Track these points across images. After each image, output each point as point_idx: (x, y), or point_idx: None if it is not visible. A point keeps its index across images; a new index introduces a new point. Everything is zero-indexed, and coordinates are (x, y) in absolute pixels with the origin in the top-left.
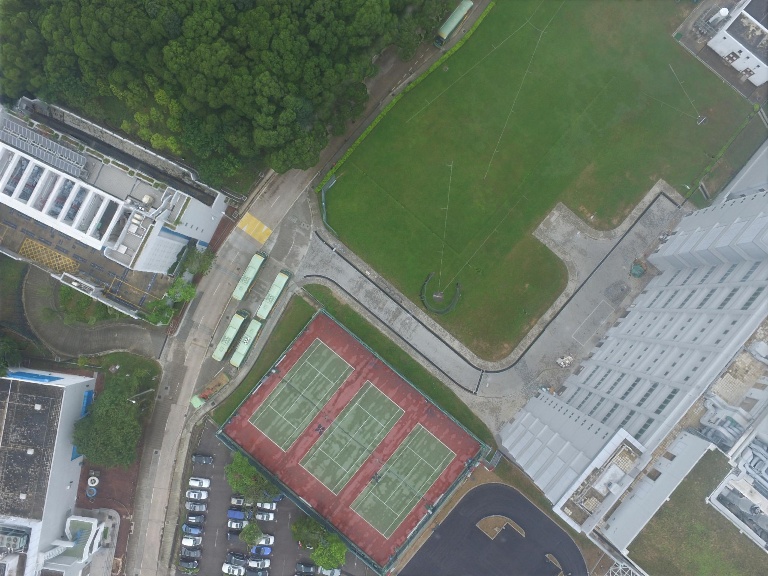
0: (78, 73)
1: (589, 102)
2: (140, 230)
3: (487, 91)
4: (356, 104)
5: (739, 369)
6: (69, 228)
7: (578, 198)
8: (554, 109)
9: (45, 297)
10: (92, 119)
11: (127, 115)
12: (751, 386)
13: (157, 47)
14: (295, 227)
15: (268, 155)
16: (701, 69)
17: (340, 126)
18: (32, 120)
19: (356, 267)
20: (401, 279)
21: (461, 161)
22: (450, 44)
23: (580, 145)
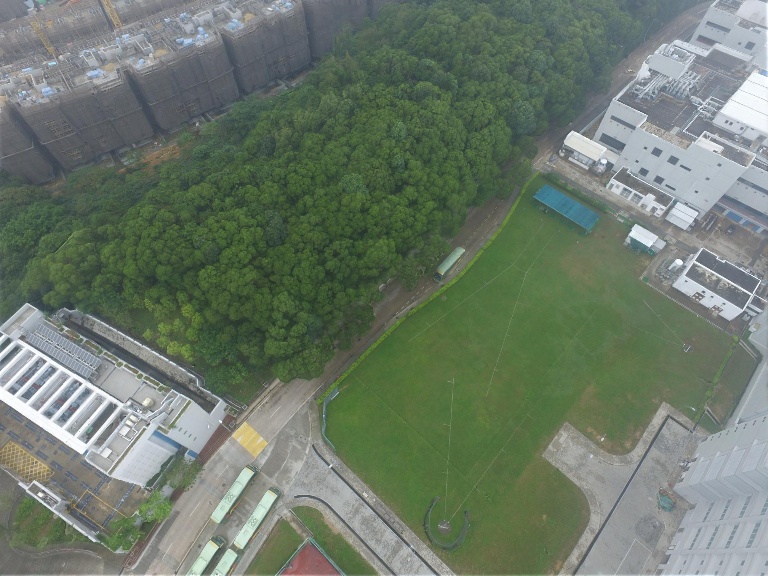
0: (120, 289)
1: (578, 329)
2: (131, 433)
3: (482, 317)
4: (363, 323)
5: None
6: (59, 429)
7: (584, 419)
8: (546, 334)
9: (1, 511)
10: (119, 327)
11: (152, 325)
12: None
13: (195, 270)
14: (292, 439)
15: (275, 364)
16: (673, 305)
17: (347, 341)
18: (64, 326)
19: (353, 487)
20: (402, 504)
21: (462, 378)
22: (447, 279)
23: (576, 367)
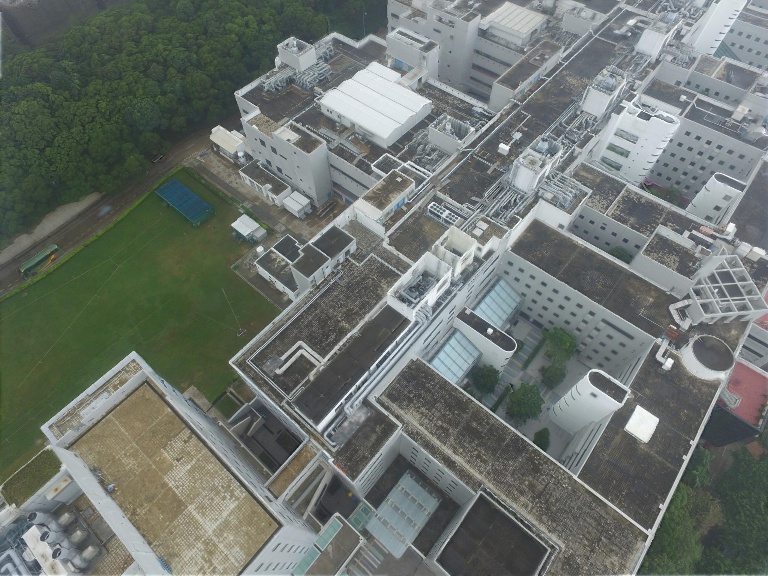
0: None
1: (142, 319)
2: None
3: (53, 311)
4: None
5: None
6: None
7: None
8: (108, 325)
9: None
10: None
11: None
12: None
13: None
14: None
15: None
16: (250, 291)
17: None
18: None
19: None
20: None
21: (3, 372)
22: None
23: (122, 356)
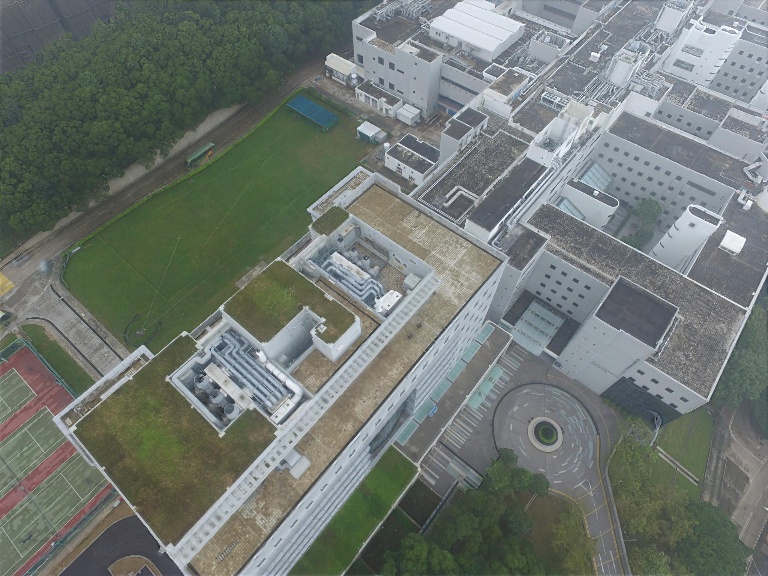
0: None
1: (294, 198)
2: None
3: (219, 193)
4: (97, 190)
5: None
6: None
7: None
8: (267, 203)
9: None
10: None
11: None
12: None
13: None
14: (35, 282)
15: None
16: None
17: (81, 204)
18: None
19: (75, 311)
20: (111, 319)
21: (187, 235)
22: None
23: (284, 224)
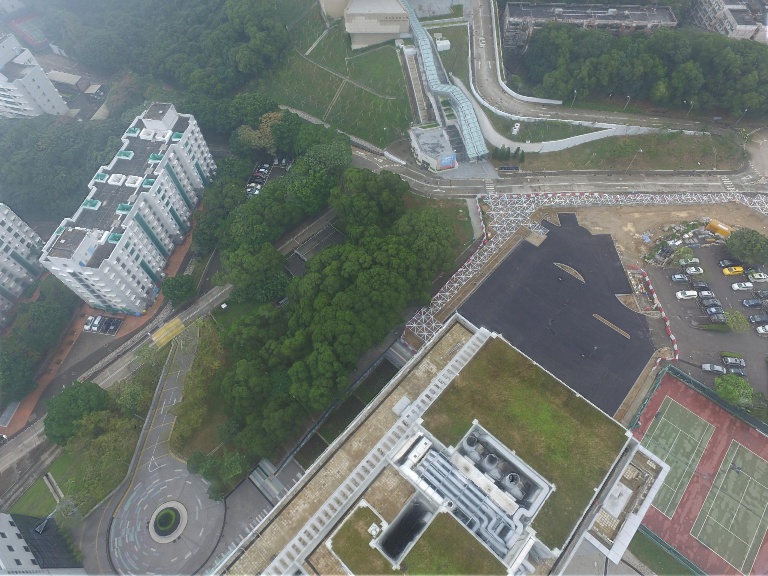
0: None
1: None
2: None
3: None
4: None
5: None
6: None
7: None
8: None
9: None
10: None
11: None
12: None
13: None
14: None
15: None
16: None
17: None
18: None
19: None
20: None
21: None
22: None
23: None
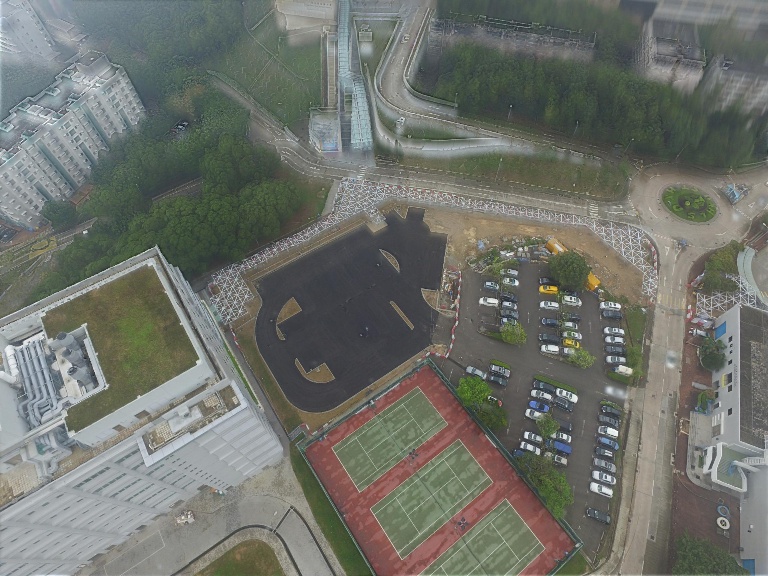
0: None
1: None
2: None
3: None
4: None
5: (1, 497)
6: None
7: None
8: None
9: None
10: None
11: None
12: (3, 475)
13: None
14: None
15: None
16: None
17: None
18: None
19: None
20: None
21: None
22: None
23: None
